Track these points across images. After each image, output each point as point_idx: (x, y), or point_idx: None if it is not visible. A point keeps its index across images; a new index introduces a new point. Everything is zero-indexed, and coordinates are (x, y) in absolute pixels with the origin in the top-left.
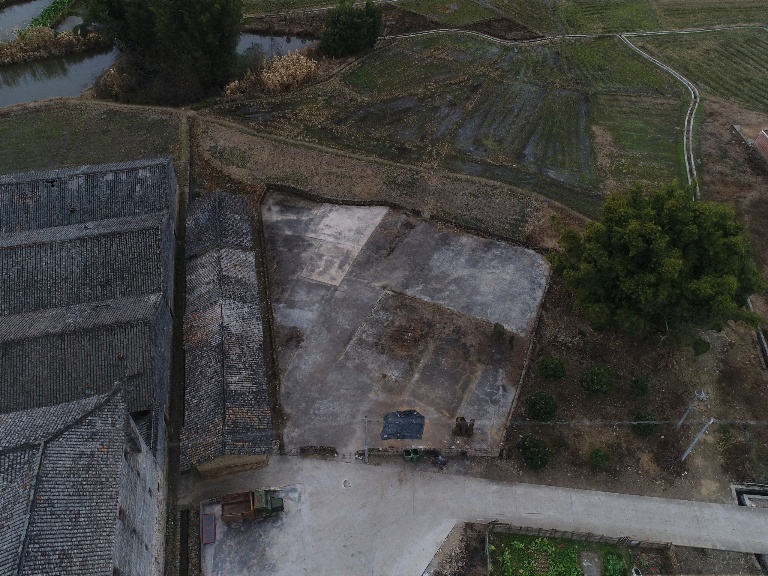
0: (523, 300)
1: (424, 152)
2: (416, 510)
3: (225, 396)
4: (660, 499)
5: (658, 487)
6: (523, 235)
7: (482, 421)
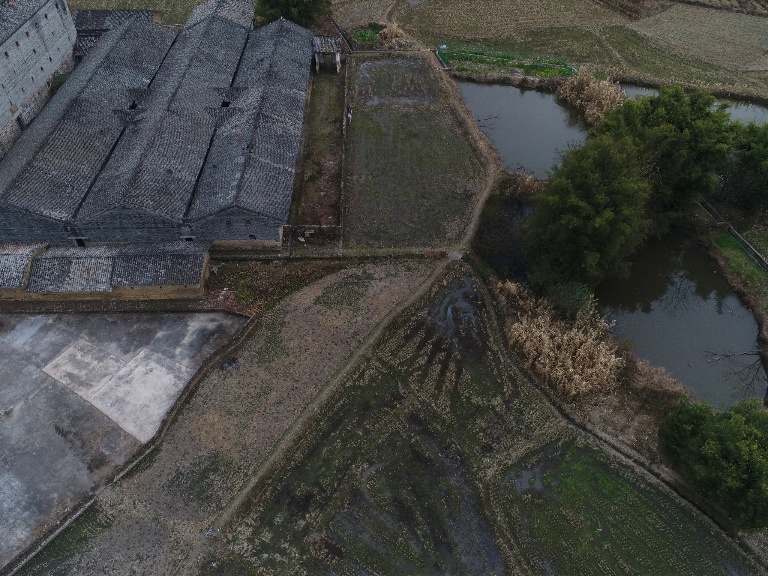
0: None
1: (285, 539)
2: None
3: None
4: None
5: None
6: None
7: None
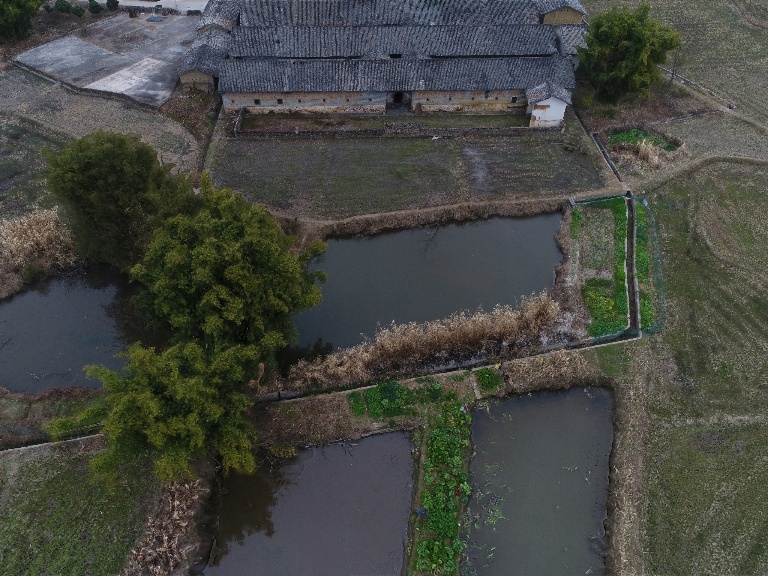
0: (54, 45)
1: None
2: (168, 3)
3: (221, 1)
4: (81, 0)
5: (77, 2)
6: (8, 72)
7: (123, 18)
